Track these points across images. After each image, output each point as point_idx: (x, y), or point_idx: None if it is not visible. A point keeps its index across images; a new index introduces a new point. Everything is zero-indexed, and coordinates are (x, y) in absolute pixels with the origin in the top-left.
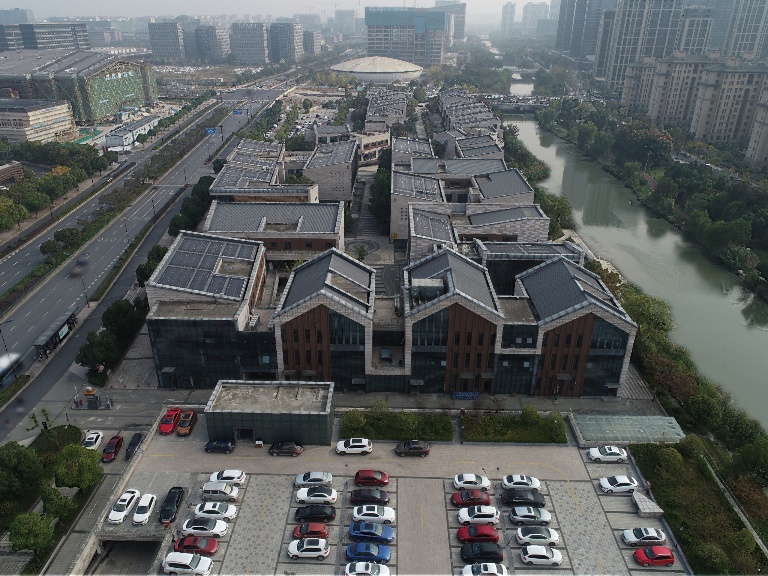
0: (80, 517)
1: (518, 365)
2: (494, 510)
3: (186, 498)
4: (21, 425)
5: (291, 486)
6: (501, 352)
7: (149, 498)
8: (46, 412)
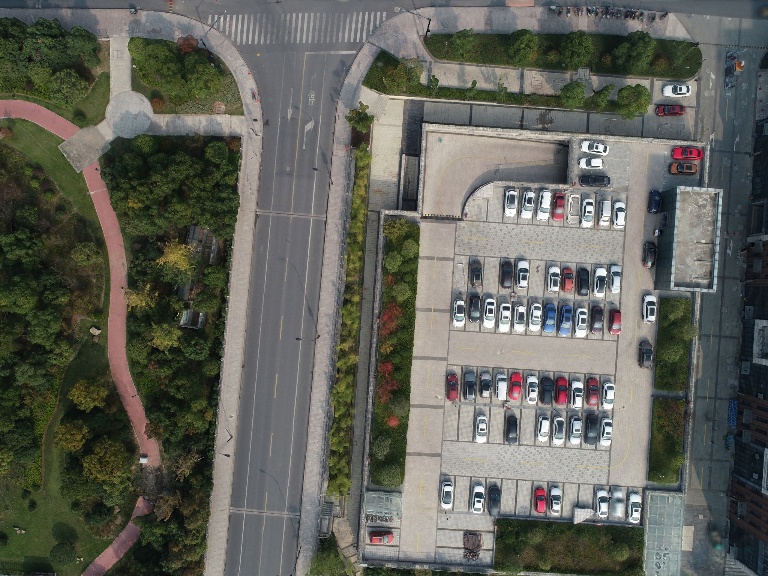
0: (601, 113)
1: (756, 468)
2: (578, 406)
3: (603, 189)
4: (706, 19)
5: (611, 263)
6: (766, 454)
7: (598, 165)
8: (724, 32)
